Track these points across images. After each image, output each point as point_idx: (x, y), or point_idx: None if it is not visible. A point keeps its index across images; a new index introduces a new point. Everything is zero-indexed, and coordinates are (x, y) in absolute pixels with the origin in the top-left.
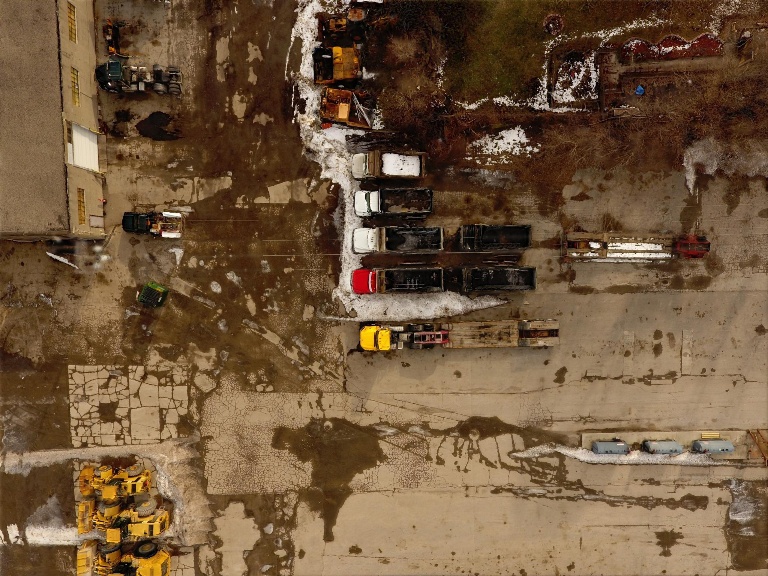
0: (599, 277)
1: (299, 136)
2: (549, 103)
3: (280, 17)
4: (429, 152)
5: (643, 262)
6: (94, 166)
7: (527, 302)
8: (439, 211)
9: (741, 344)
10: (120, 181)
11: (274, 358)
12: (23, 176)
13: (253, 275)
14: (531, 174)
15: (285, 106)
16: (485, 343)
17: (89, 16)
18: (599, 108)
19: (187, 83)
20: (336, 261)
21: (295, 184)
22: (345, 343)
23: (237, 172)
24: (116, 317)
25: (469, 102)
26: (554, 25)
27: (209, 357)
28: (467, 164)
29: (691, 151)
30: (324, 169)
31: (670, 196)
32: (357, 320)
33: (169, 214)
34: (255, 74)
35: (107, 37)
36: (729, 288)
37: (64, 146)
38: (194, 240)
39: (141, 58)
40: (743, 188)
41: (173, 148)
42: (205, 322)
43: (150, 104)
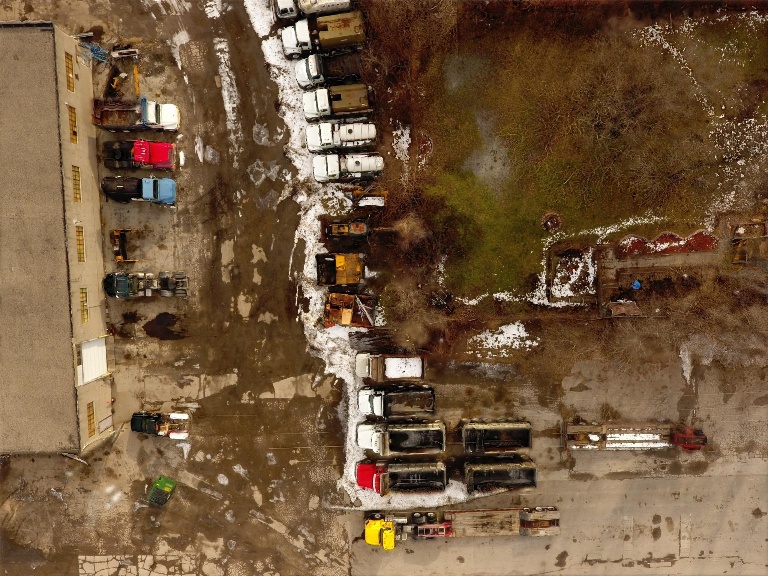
0: (598, 464)
1: (303, 334)
2: (548, 298)
3: (283, 220)
4: (431, 350)
5: (641, 449)
6: (103, 369)
7: (528, 490)
8: (441, 403)
9: (738, 527)
10: (128, 380)
11: (280, 547)
12: (34, 398)
13: (259, 467)
14: (531, 366)
15: (289, 305)
16: (487, 532)
17: (96, 226)
18: (597, 303)
19: (193, 285)
20: (340, 452)
21: (300, 379)
22: (350, 531)
23: (243, 369)
24: (125, 509)
25: (469, 298)
26: (552, 223)
27: (217, 546)
28: (468, 358)
29: (687, 344)
30: (328, 365)
31: (667, 386)
32: (362, 509)
33: (177, 417)
34: (259, 275)
35: (114, 248)
36: (726, 473)
37: (74, 369)
38: (201, 435)
39: (148, 262)
40: (739, 377)
41: (180, 347)
42: (212, 513)
43: (157, 305)
